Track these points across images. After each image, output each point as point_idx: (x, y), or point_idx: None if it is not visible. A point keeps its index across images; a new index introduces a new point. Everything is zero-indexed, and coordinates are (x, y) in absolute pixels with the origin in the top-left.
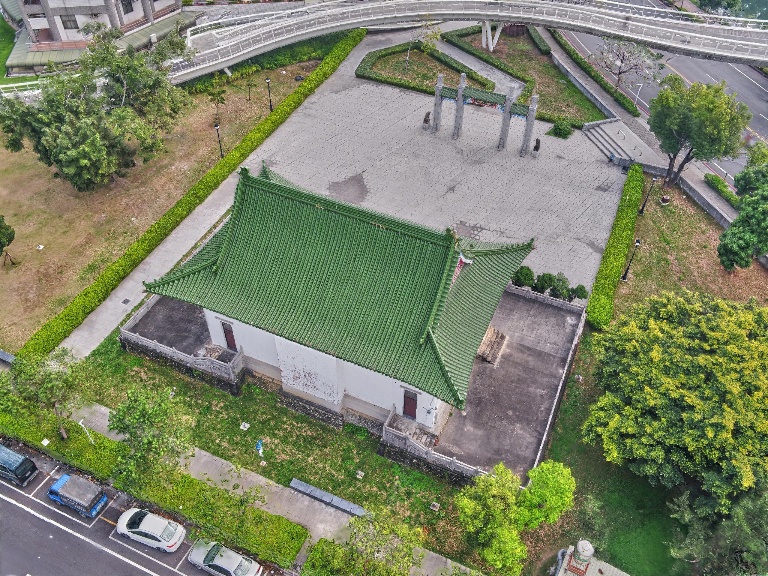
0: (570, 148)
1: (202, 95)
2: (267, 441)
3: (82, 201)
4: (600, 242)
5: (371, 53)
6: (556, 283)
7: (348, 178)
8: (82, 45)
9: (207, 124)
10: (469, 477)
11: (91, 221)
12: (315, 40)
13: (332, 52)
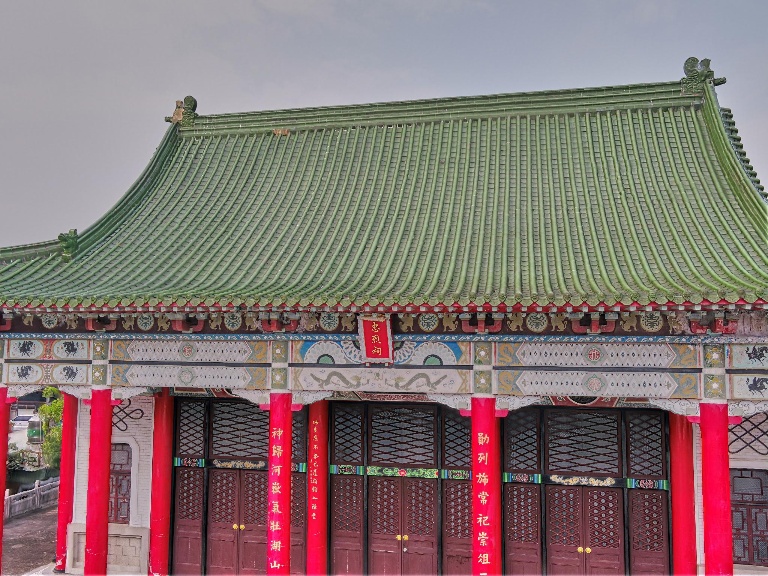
0: None
1: None
2: None
3: None
4: None
5: None
6: None
7: None
8: None
9: None
10: None
11: None
12: None
13: None
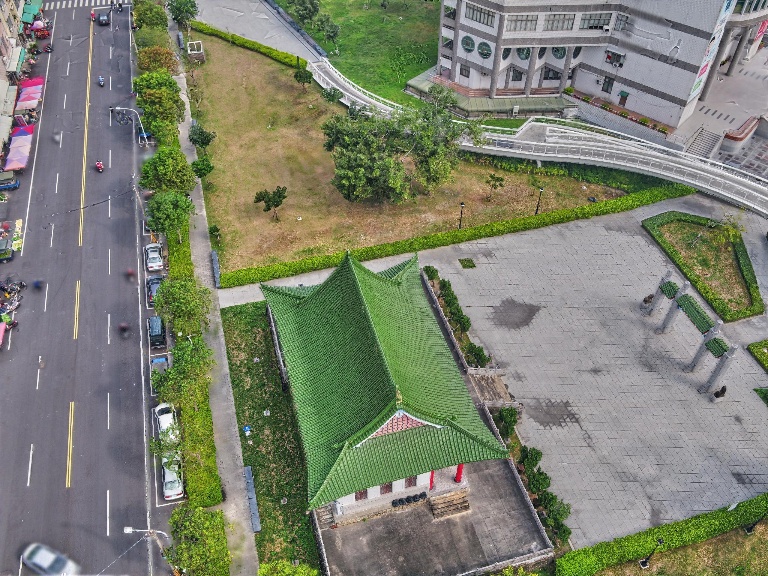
0: (762, 419)
1: (503, 172)
2: (267, 432)
3: (350, 204)
4: (667, 518)
5: (674, 212)
6: (554, 508)
7: (527, 304)
8: (462, 91)
9: (481, 197)
10: (324, 567)
11: (340, 220)
12: (639, 174)
13: (641, 192)
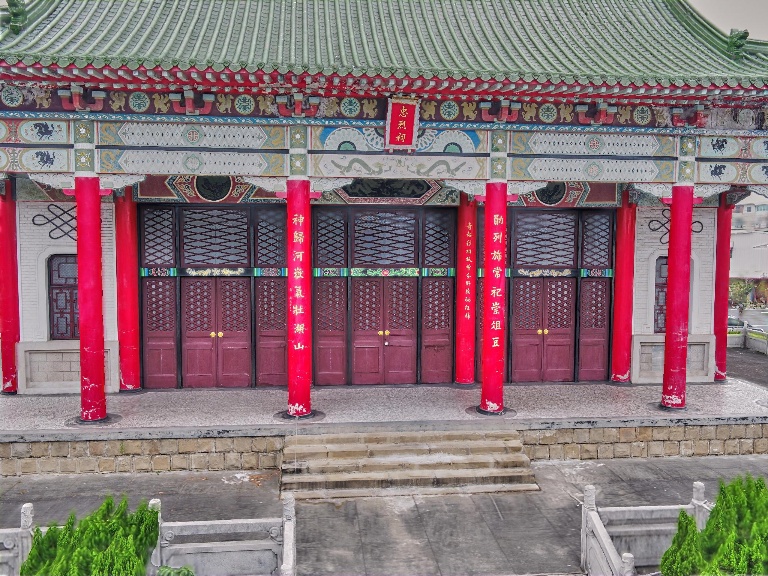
0: None
1: None
2: None
3: None
4: None
5: None
6: None
7: None
8: None
9: None
10: None
11: None
12: None
13: None
